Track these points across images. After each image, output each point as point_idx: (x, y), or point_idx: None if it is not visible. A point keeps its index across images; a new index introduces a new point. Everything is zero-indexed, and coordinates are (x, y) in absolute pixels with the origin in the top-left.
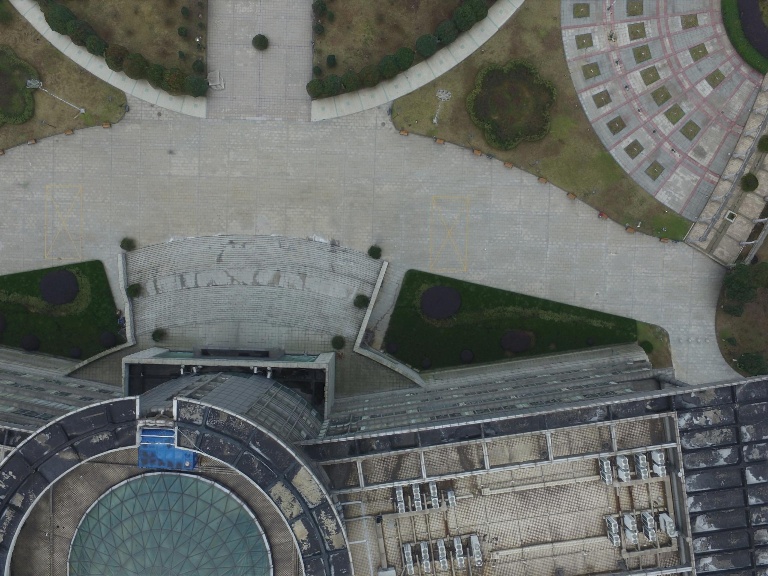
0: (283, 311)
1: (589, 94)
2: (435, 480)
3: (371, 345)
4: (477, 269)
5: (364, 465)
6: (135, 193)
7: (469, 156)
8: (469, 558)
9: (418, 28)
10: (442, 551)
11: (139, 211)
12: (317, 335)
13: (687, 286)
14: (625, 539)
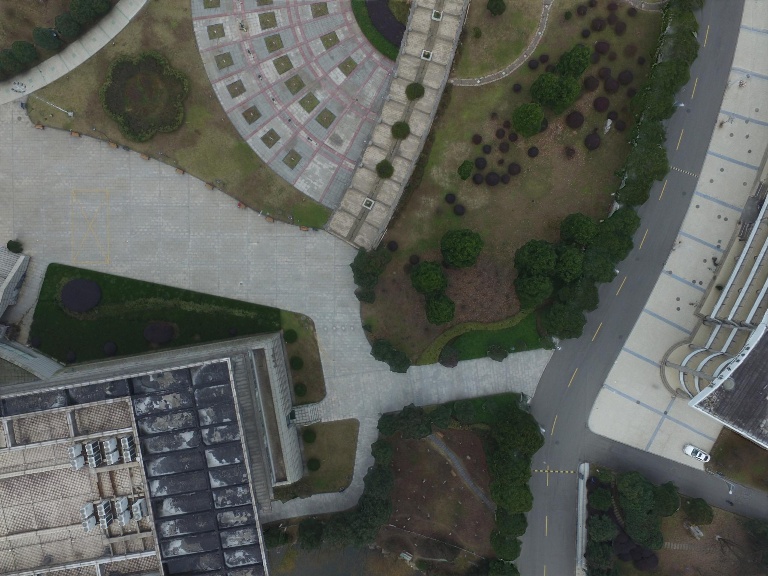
0: None
1: (223, 84)
2: None
3: (16, 339)
4: (120, 261)
5: None
6: None
7: (107, 149)
8: None
9: (49, 22)
10: None
11: None
12: None
13: (330, 274)
14: (111, 525)
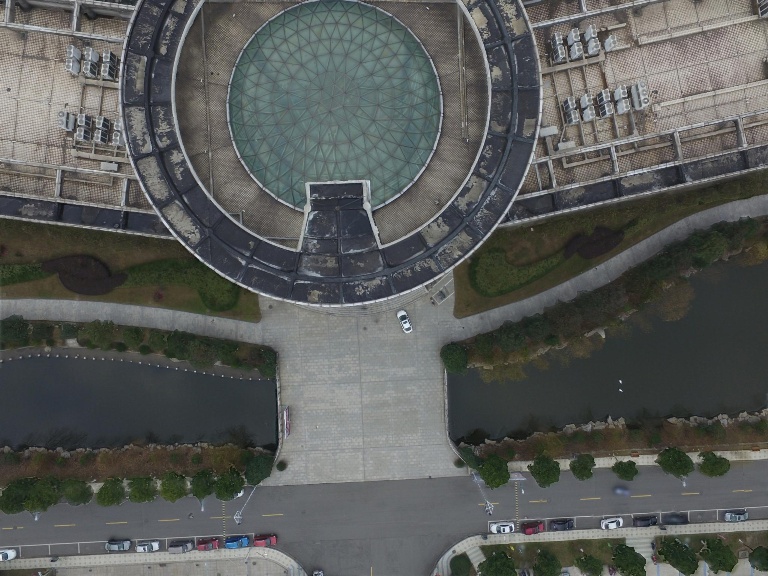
0: None
1: None
2: (596, 13)
3: None
4: None
5: None
6: None
7: None
8: (631, 109)
9: None
10: (606, 93)
11: None
12: None
13: None
14: None
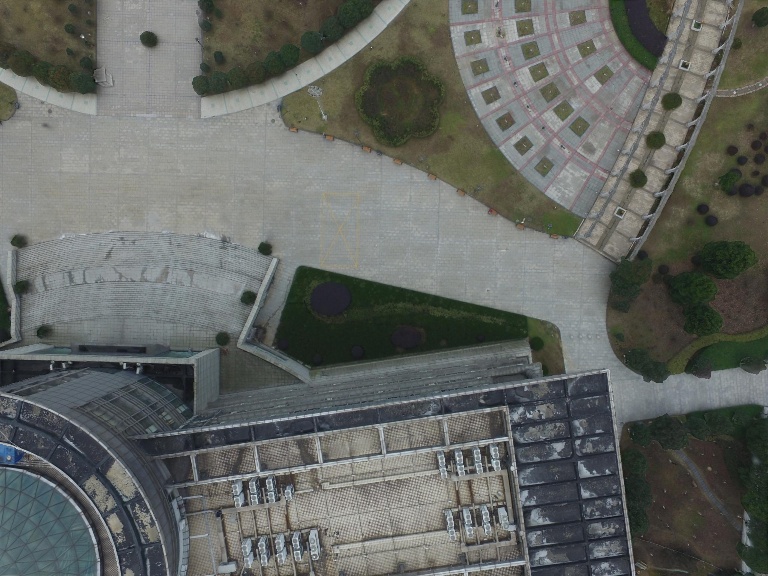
0: (169, 307)
1: (478, 90)
2: (269, 474)
3: (262, 341)
4: (368, 265)
5: (205, 459)
6: (26, 190)
7: (359, 153)
8: (309, 552)
9: (307, 25)
10: (278, 545)
11: (30, 208)
12: (202, 331)
13: (578, 282)
14: (466, 533)
